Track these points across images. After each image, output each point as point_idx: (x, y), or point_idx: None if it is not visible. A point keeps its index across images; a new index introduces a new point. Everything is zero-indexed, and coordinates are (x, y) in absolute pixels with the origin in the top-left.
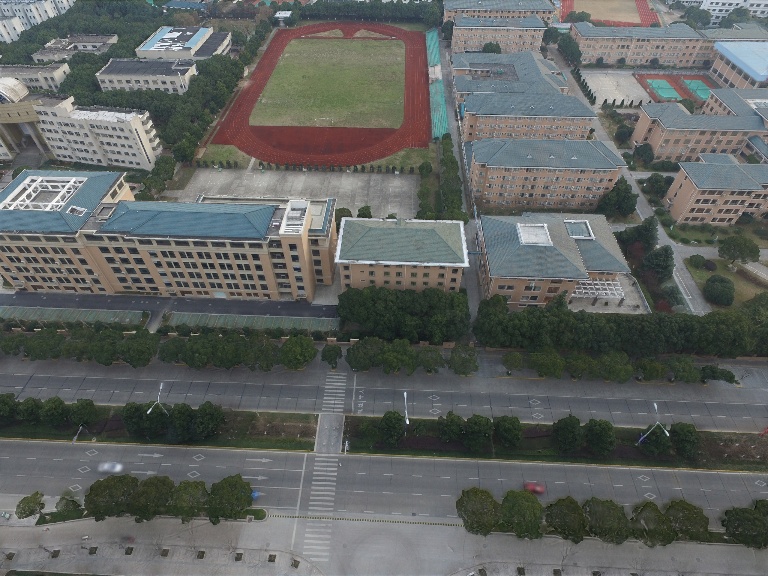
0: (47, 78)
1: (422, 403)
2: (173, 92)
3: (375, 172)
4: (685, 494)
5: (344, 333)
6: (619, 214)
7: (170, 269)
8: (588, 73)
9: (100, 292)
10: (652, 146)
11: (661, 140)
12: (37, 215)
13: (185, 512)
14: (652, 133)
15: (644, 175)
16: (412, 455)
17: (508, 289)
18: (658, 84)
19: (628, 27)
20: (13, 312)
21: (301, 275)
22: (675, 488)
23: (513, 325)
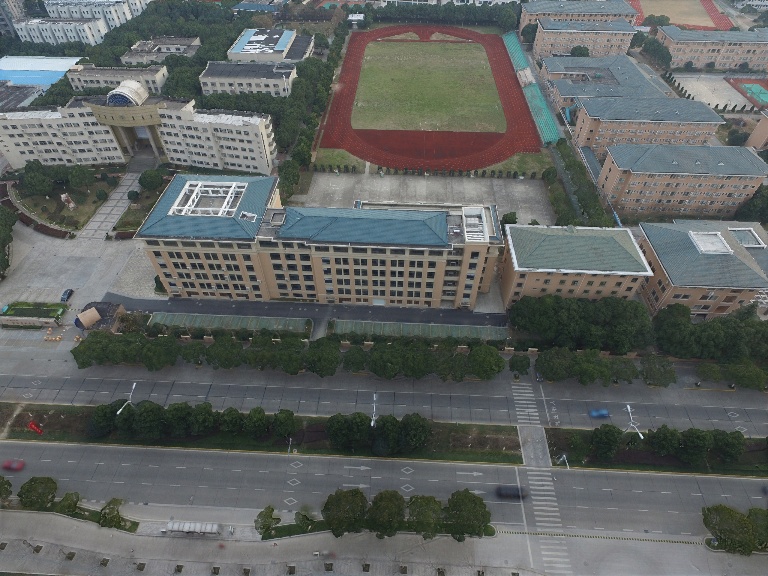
0: (148, 81)
1: (618, 415)
2: (275, 95)
3: (495, 177)
4: None
5: (516, 342)
6: (758, 221)
7: (337, 276)
8: (678, 77)
9: (255, 299)
10: None
11: None
12: (211, 221)
13: (431, 529)
14: None
15: None
16: (626, 469)
17: (682, 298)
18: (753, 89)
19: (719, 31)
20: (173, 319)
21: (472, 283)
22: None
23: (707, 336)
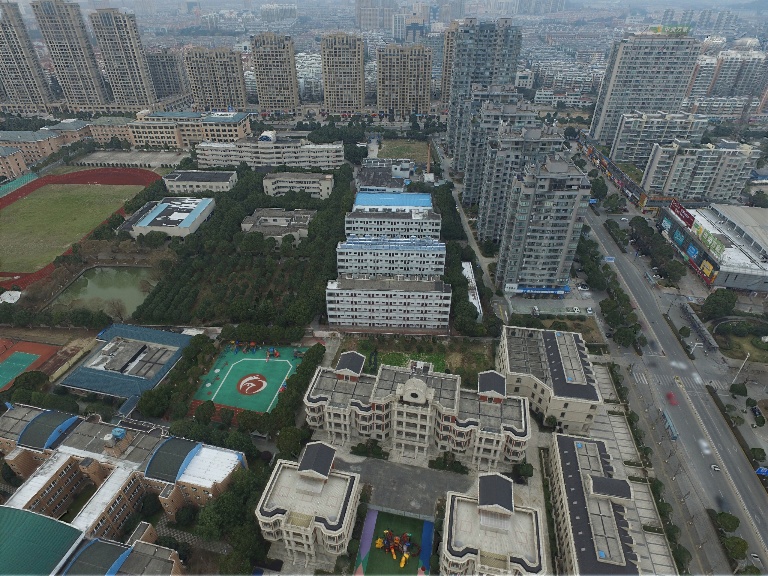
0: None
1: None
2: None
3: None
4: None
5: None
6: None
7: None
8: None
9: None
10: None
11: None
12: None
13: None
14: None
15: None
16: None
17: None
18: None
19: None
20: None
21: None
22: None
23: None
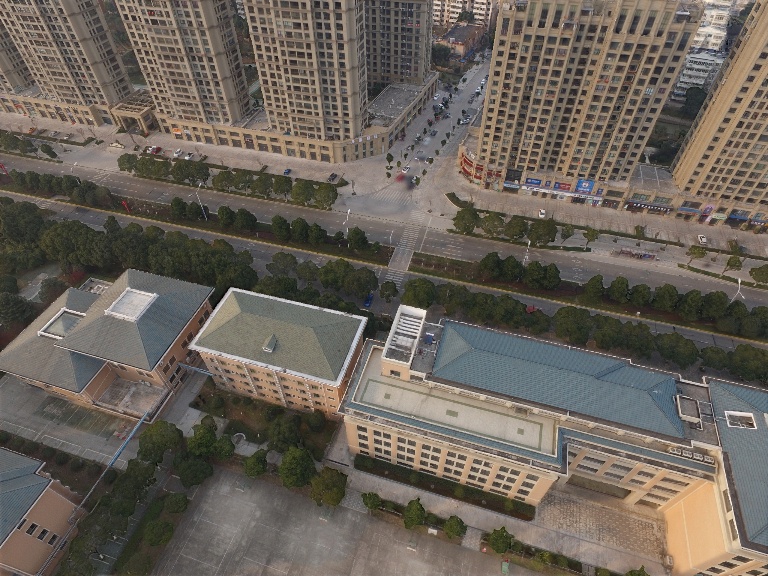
0: None
1: None
2: None
3: None
4: (205, 202)
5: None
6: None
7: None
8: None
9: None
10: None
11: None
12: None
13: None
14: None
15: None
16: None
17: None
18: None
19: None
20: None
21: None
22: (207, 205)
23: None
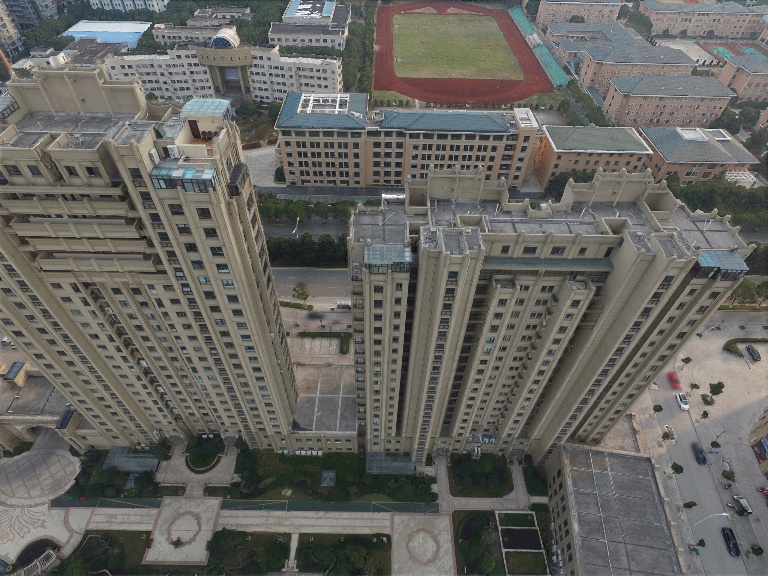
0: None
1: None
2: None
3: None
4: None
5: None
6: None
7: (422, 161)
8: (658, 42)
9: (354, 185)
10: (736, 90)
11: (746, 83)
12: (331, 117)
13: None
14: (736, 80)
15: None
16: None
17: None
18: None
19: None
20: (294, 198)
21: (521, 165)
22: None
23: (692, 191)
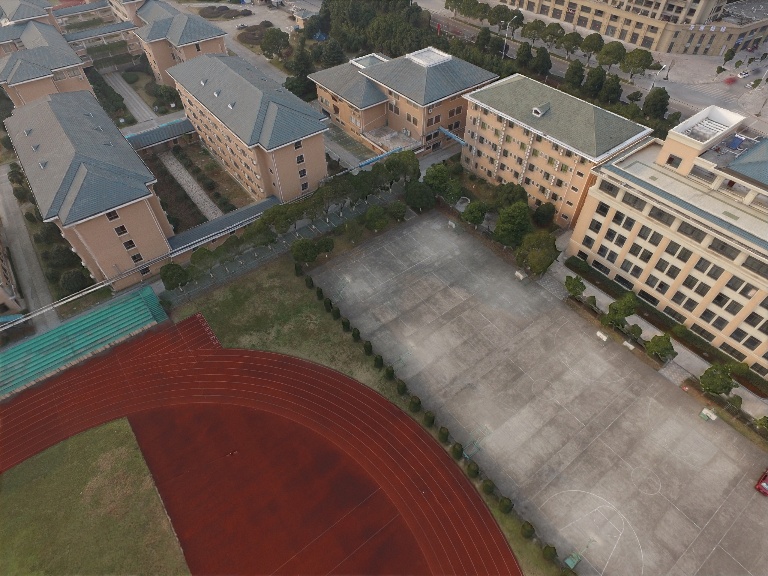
0: None
1: None
2: None
3: None
4: None
5: None
6: None
7: None
8: None
9: None
10: None
11: None
12: None
13: None
14: None
15: (143, 113)
16: None
17: None
18: None
19: None
20: None
21: None
22: None
23: None
